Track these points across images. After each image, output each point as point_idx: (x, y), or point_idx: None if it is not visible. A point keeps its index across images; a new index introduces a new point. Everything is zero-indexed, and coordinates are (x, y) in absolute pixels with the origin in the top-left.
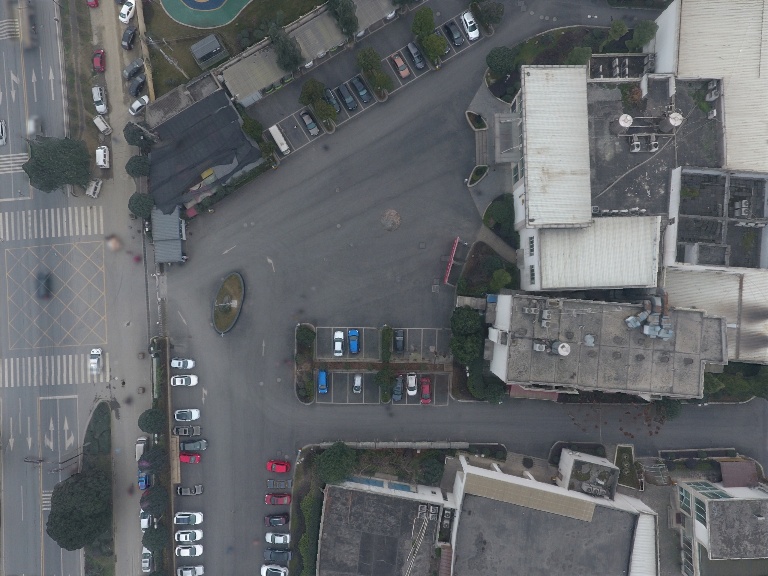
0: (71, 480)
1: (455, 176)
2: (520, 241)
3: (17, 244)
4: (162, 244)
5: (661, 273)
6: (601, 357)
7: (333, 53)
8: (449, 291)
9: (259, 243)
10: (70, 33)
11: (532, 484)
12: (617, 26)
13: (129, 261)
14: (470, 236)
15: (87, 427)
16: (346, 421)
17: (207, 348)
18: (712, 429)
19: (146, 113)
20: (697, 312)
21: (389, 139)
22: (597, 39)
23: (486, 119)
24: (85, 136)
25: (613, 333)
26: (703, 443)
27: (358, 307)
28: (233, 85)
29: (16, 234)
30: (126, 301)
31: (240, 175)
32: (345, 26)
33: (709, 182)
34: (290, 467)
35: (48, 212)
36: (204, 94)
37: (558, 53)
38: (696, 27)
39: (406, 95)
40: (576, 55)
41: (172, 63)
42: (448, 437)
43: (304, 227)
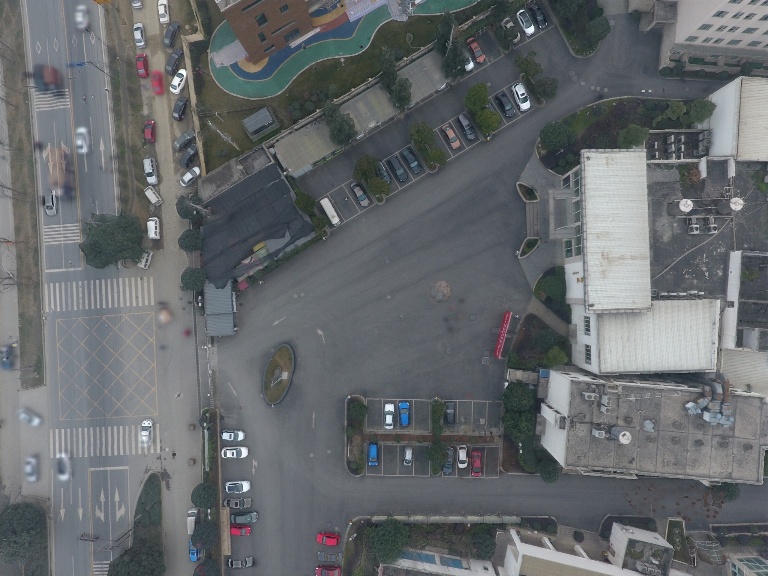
0: (127, 558)
1: (505, 248)
2: (572, 314)
3: (68, 315)
4: (214, 318)
5: (718, 355)
6: (660, 442)
7: (383, 124)
8: (499, 363)
9: (309, 314)
10: (121, 104)
11: (587, 564)
12: (676, 107)
13: (180, 332)
14: (520, 308)
15: (138, 499)
16: (396, 493)
17: (257, 419)
18: (764, 503)
19: (198, 187)
20: (757, 397)
21: (439, 210)
22: (649, 111)
23: (537, 191)
24: (136, 207)
25: (672, 418)
26: (754, 517)
27: (408, 379)
28: (285, 158)
29: (67, 305)
30: (177, 372)
31: (292, 249)
32: (398, 101)
33: (767, 264)
34: (340, 539)
35: (99, 283)
36: (256, 167)
37: (610, 125)
38: (756, 110)
39: (456, 166)
40: (633, 134)
41: (227, 140)
42: (498, 510)
43: (354, 298)
